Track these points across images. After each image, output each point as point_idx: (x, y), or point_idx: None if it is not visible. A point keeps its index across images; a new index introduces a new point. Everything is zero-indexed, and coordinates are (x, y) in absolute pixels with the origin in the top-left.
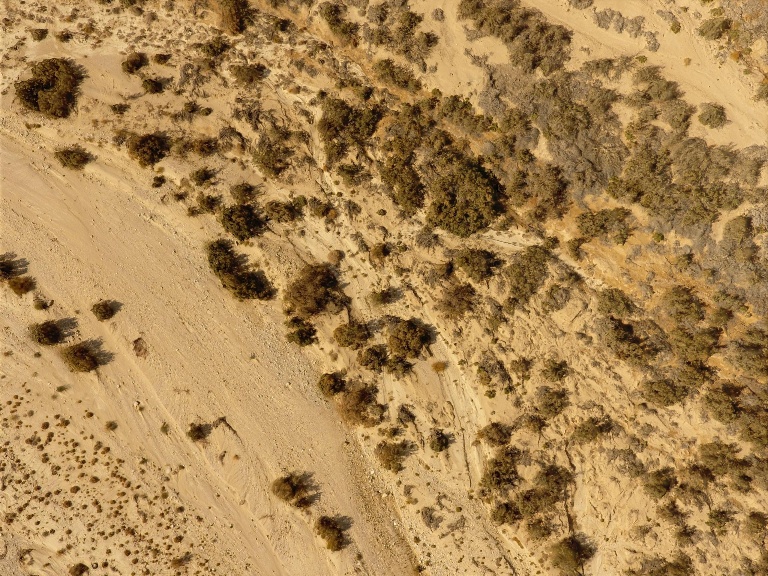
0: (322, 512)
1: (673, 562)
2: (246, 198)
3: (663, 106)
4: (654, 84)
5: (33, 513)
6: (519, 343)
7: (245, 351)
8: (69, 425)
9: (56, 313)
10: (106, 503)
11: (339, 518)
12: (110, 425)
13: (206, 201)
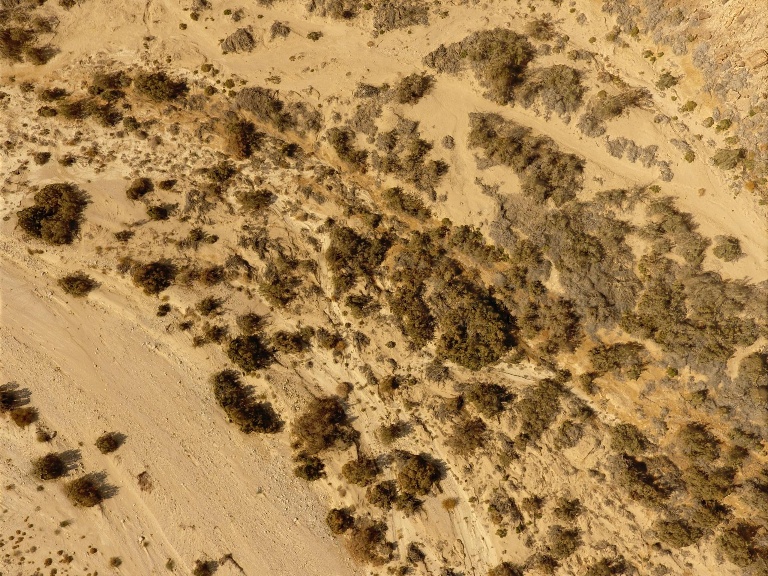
0: None
1: None
2: (253, 329)
3: (677, 239)
4: (668, 219)
5: None
6: (531, 480)
7: (252, 485)
8: (72, 561)
9: (59, 445)
10: None
11: None
12: (114, 562)
13: (212, 334)
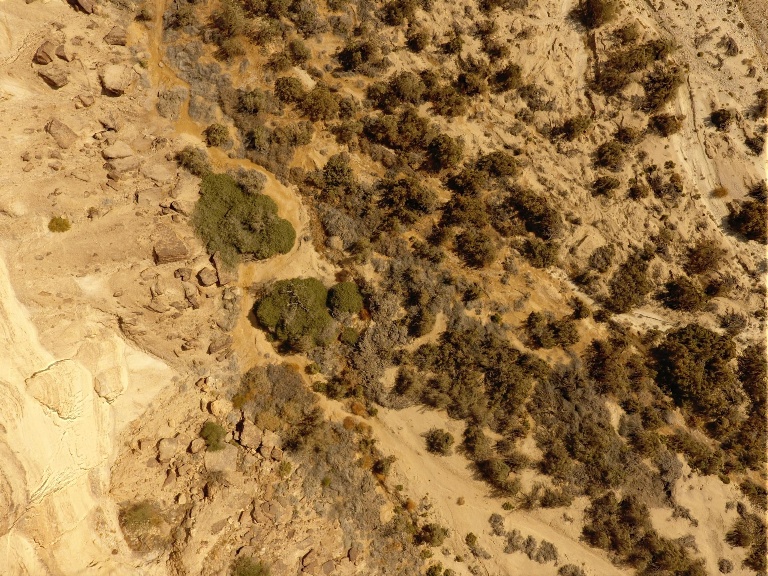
0: None
1: (497, 7)
2: None
3: (490, 455)
4: None
5: None
6: (640, 215)
7: None
8: None
9: None
10: None
11: None
12: None
13: None
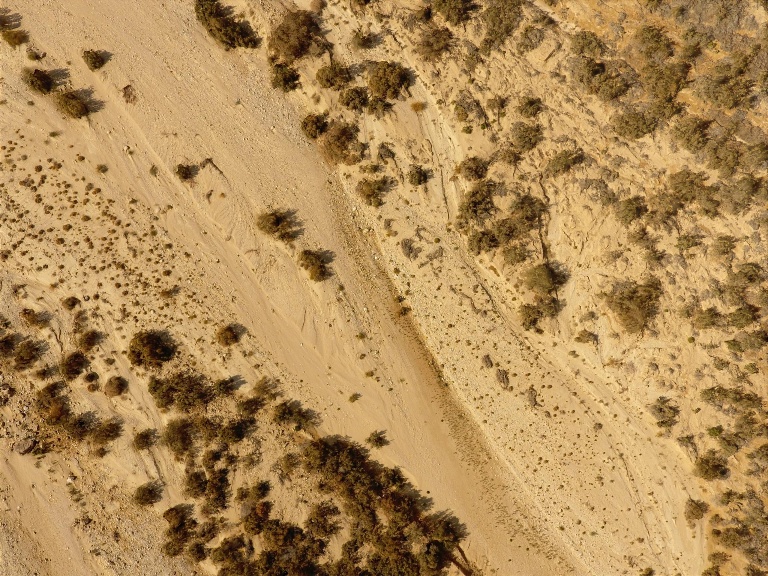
0: (305, 246)
1: (643, 284)
2: None
3: None
4: None
5: (27, 250)
6: (495, 82)
7: (231, 97)
8: (61, 168)
9: (48, 64)
10: (97, 240)
11: (322, 252)
12: (101, 167)
13: None
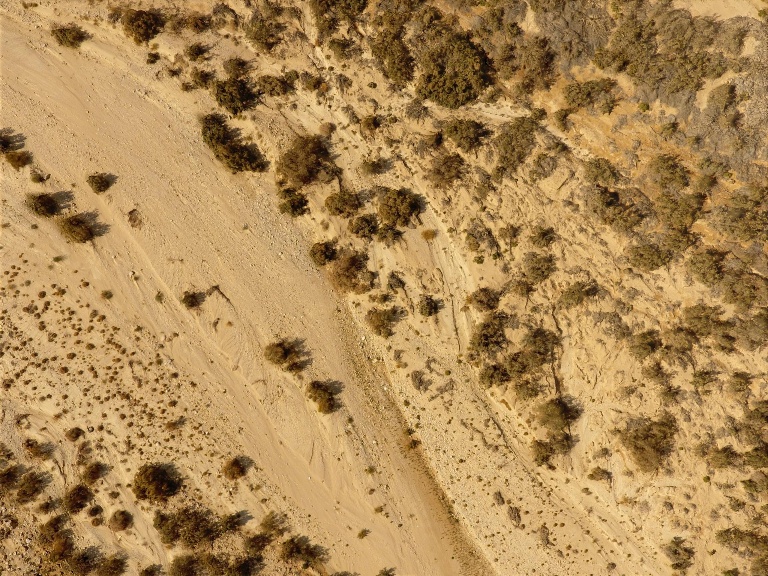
0: (314, 377)
1: (658, 421)
2: (239, 72)
3: None
4: None
5: (30, 379)
6: (507, 211)
7: (238, 222)
8: (65, 294)
9: (53, 186)
10: (102, 369)
11: (330, 383)
12: (106, 294)
13: (200, 74)
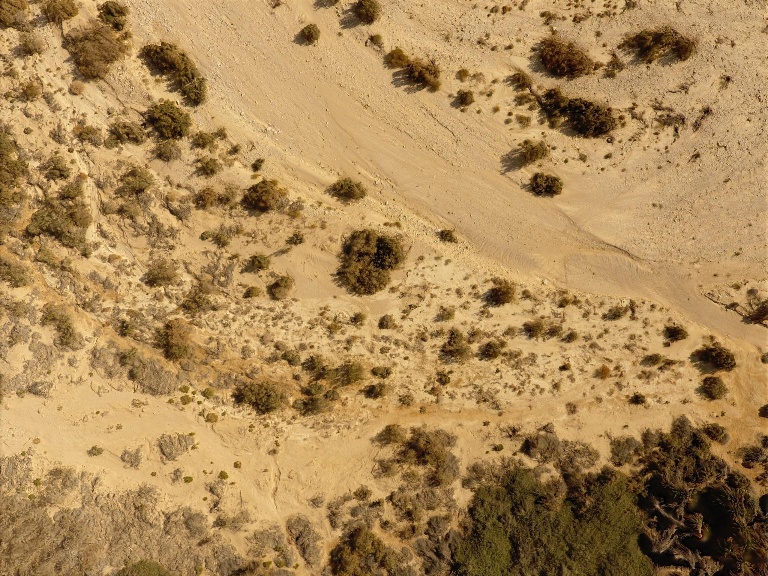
0: None
1: None
2: None
3: None
4: None
5: None
6: None
7: None
8: None
9: (361, 33)
10: None
11: None
12: None
13: (200, 139)
